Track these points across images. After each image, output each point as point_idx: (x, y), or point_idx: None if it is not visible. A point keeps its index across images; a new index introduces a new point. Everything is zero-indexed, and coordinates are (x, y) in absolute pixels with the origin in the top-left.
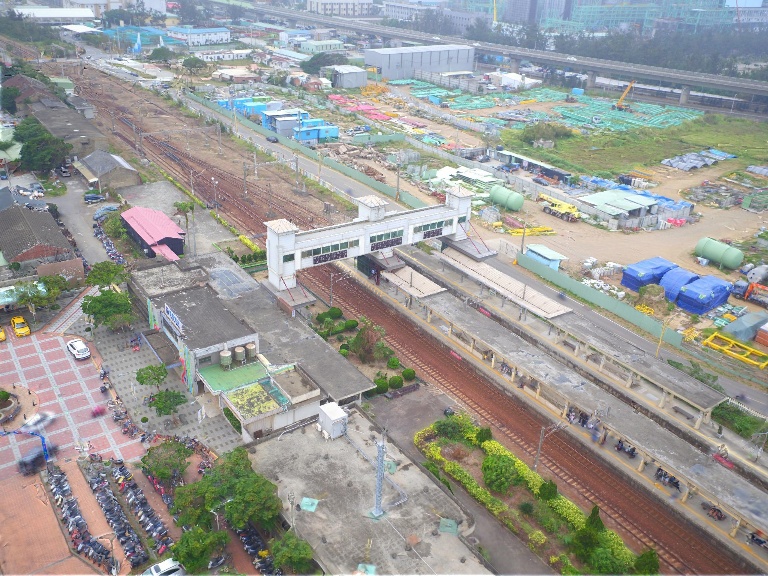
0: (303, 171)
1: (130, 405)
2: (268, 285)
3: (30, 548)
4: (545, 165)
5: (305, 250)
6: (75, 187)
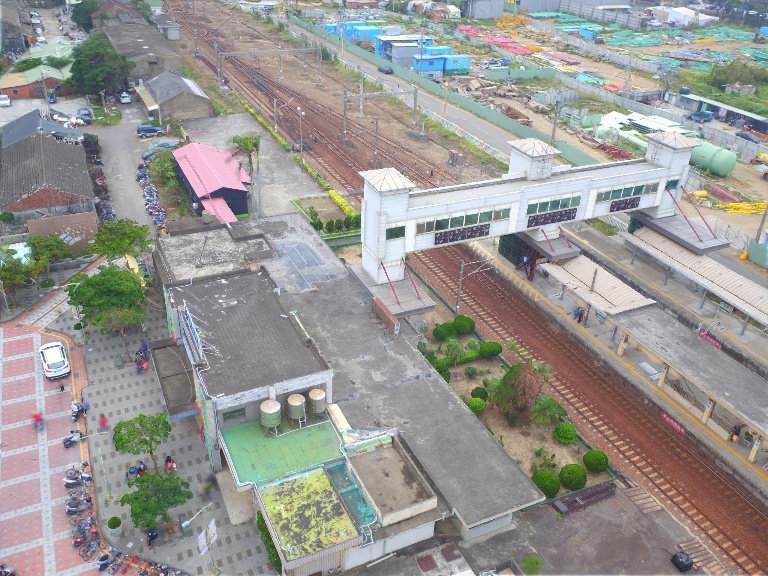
0: (422, 109)
1: (103, 480)
2: (360, 273)
3: None
4: (753, 115)
5: (423, 221)
6: (132, 116)
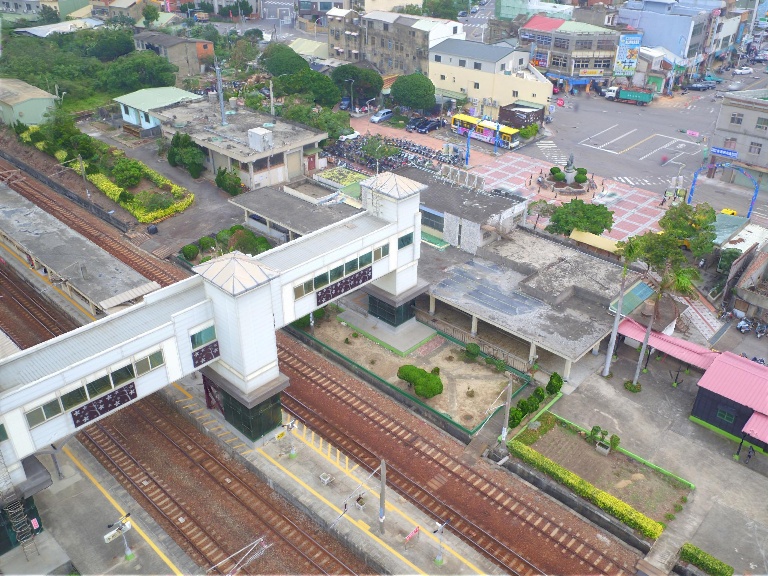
0: None
1: None
2: None
3: (431, 143)
4: None
5: None
6: None
